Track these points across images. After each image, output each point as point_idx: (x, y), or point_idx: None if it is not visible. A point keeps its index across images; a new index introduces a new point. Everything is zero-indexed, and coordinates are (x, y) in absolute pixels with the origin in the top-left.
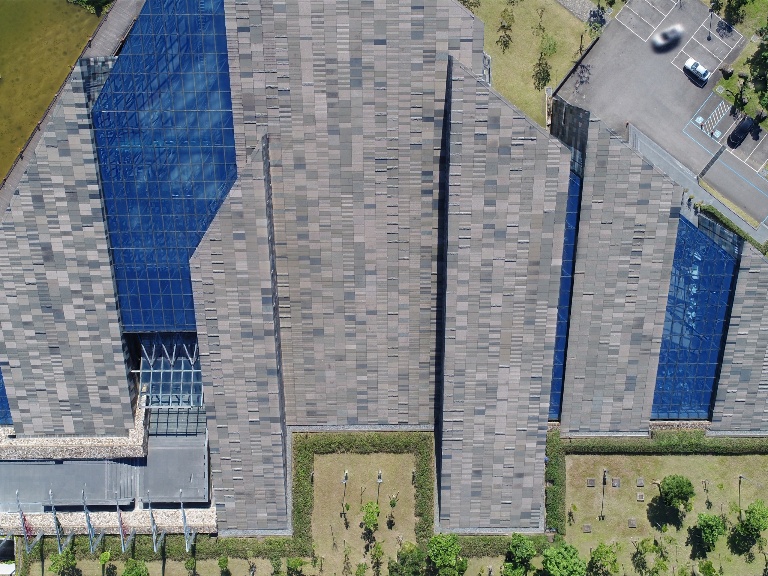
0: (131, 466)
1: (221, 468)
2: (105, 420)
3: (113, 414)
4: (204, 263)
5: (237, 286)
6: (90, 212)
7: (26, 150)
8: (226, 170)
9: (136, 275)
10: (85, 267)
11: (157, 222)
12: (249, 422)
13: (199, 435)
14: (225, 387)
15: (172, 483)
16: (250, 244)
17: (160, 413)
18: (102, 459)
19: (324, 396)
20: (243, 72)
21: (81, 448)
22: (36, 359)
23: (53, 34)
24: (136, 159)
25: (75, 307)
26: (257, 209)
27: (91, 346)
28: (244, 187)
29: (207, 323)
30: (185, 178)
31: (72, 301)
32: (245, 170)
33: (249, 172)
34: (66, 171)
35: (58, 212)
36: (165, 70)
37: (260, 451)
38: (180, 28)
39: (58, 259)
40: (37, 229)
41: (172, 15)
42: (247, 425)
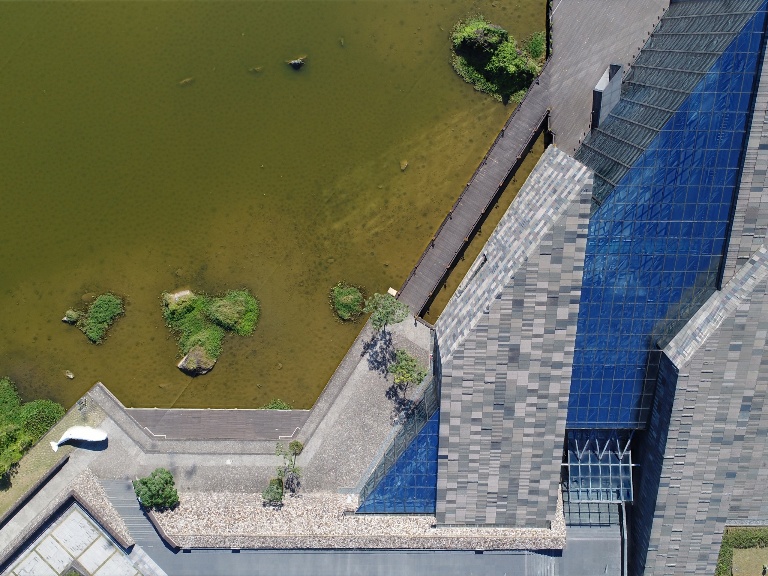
0: (547, 556)
1: (655, 564)
2: (528, 512)
3: (538, 506)
4: (693, 372)
5: (720, 394)
6: (566, 316)
7: (437, 238)
8: (707, 278)
9: (592, 375)
10: (547, 368)
11: (626, 325)
12: (695, 521)
13: (613, 526)
14: (681, 488)
15: (587, 574)
16: (744, 355)
17: (570, 503)
18: (523, 550)
19: (751, 492)
20: (754, 187)
21: (505, 539)
22: (475, 453)
23: (459, 122)
24: (620, 266)
25: (527, 405)
26: (760, 322)
27: (533, 442)
28: (753, 301)
29: (680, 428)
30: (664, 284)
31: (526, 399)
32: (759, 285)
33: (762, 287)
34: (553, 277)
35: (535, 316)
36: (672, 183)
37: (698, 549)
38: (697, 144)
39: (523, 360)
40: (510, 331)
41: (693, 131)
42: (692, 524)
